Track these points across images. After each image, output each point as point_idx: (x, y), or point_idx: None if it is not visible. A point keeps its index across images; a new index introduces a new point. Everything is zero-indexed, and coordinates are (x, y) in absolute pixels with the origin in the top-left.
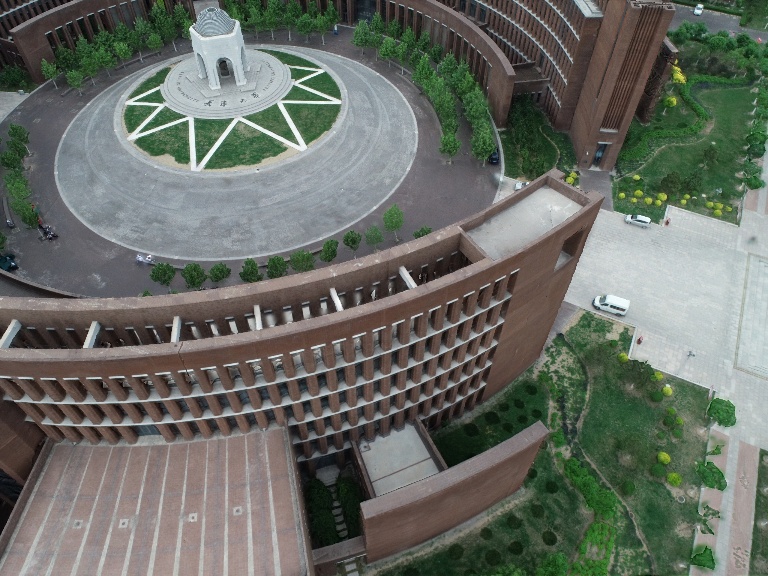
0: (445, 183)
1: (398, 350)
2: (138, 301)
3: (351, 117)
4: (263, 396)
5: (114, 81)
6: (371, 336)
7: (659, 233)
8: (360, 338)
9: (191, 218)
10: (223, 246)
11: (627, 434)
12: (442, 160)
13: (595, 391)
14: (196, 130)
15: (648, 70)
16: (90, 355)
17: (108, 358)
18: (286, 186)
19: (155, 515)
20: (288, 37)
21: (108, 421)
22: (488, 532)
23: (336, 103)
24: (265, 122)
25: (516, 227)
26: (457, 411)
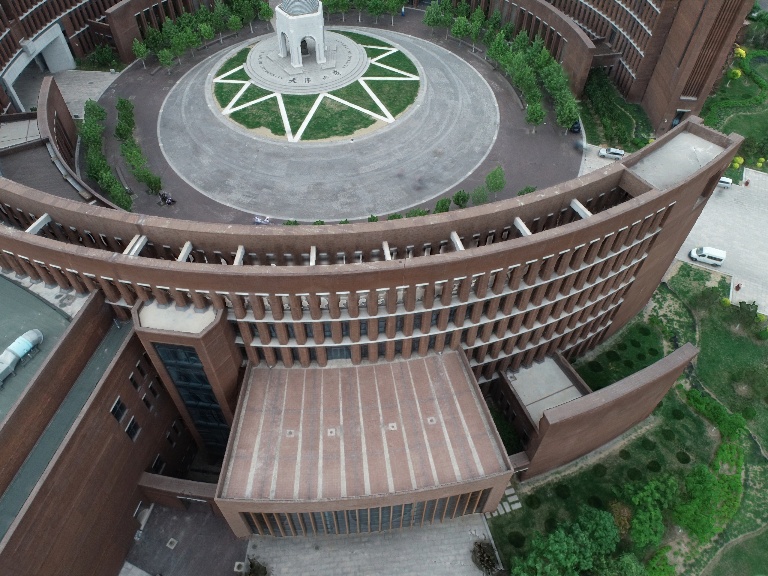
0: (532, 150)
1: (568, 276)
2: (354, 227)
3: (431, 92)
4: (450, 318)
5: (198, 61)
6: (556, 259)
7: (740, 193)
8: (545, 261)
9: (298, 184)
10: (333, 209)
11: (739, 368)
12: (525, 130)
13: (704, 332)
14: (286, 105)
15: (733, 38)
16: (327, 270)
17: (344, 272)
18: (382, 154)
19: (358, 425)
20: (357, 19)
21: (311, 342)
22: (626, 453)
23: (415, 79)
24: (350, 97)
25: (668, 166)
26: (583, 349)
